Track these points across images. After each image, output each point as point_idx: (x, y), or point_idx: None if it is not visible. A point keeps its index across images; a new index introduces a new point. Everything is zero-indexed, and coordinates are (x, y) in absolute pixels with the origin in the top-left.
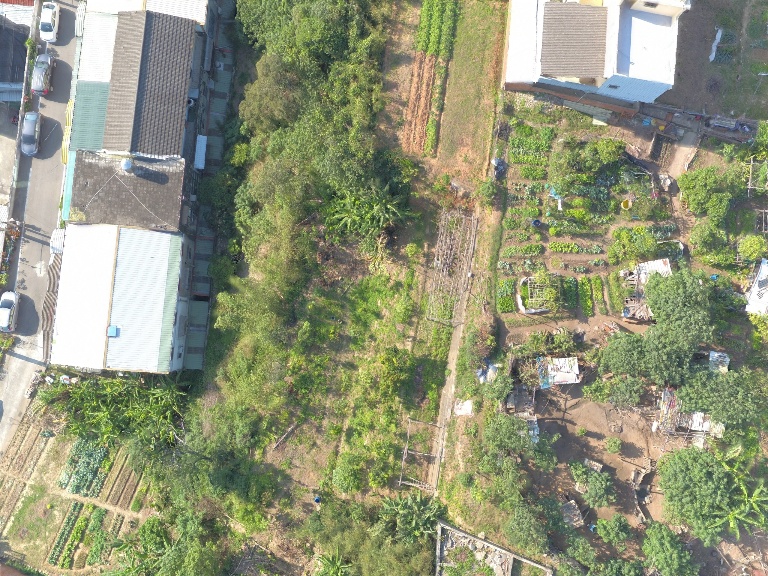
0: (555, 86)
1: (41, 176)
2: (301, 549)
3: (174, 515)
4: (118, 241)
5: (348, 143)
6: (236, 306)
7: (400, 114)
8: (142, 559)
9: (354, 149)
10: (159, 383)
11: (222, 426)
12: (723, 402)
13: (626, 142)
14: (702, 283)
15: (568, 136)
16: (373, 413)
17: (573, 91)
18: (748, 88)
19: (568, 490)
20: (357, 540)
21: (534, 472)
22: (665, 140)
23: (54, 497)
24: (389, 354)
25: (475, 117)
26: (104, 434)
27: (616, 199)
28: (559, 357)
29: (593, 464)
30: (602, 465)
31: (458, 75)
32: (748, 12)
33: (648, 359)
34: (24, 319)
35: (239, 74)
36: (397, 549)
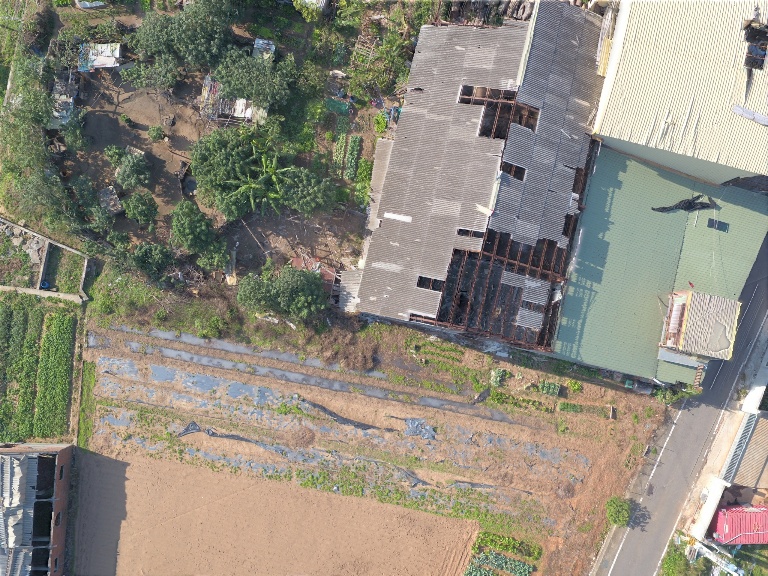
0: None
1: None
2: None
3: None
4: None
5: None
6: None
7: None
8: None
9: None
10: None
11: None
12: (249, 77)
13: None
14: None
15: None
16: None
17: None
18: None
19: (114, 180)
20: None
21: (82, 163)
22: None
23: None
24: None
25: None
26: None
27: None
28: (102, 43)
29: (134, 150)
30: None
31: None
32: None
33: (170, 30)
34: None
35: None
36: None
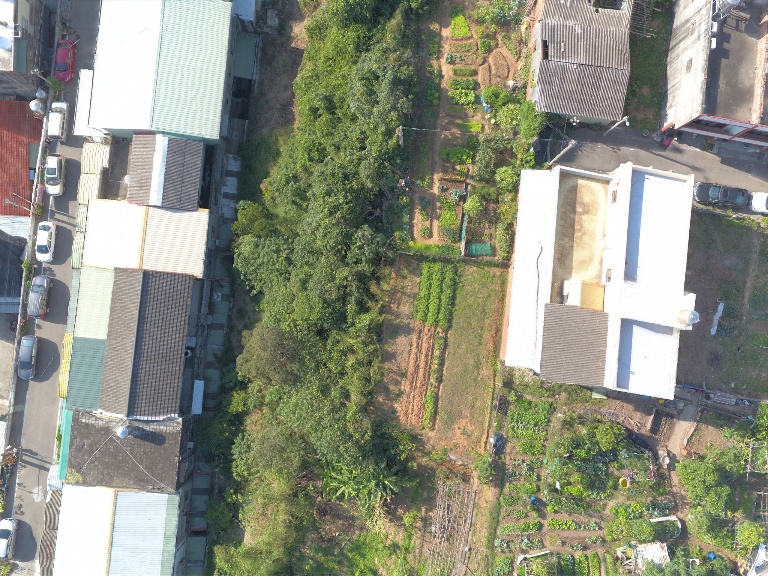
0: None
1: (38, 399)
2: None
3: None
4: (115, 506)
5: (346, 423)
6: None
7: (398, 386)
8: None
9: (352, 431)
10: None
11: None
12: None
13: (625, 416)
14: (699, 563)
15: (567, 417)
16: None
17: None
18: (749, 361)
19: None
20: None
21: None
22: (665, 414)
23: None
24: None
25: (474, 388)
26: None
27: (614, 474)
28: None
29: None
30: None
31: (457, 345)
32: (751, 282)
33: None
34: (22, 545)
35: (237, 307)
36: None
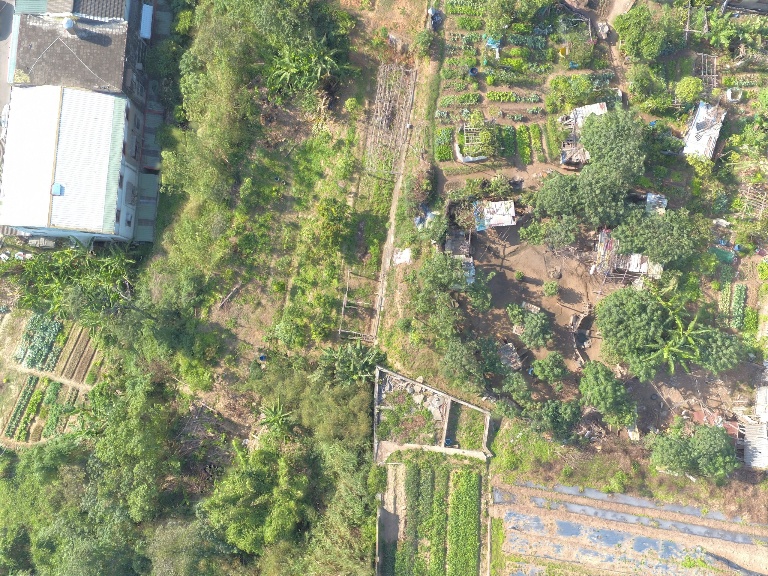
0: None
1: None
2: (247, 408)
3: (124, 380)
4: (62, 101)
5: None
6: (179, 165)
7: None
8: (92, 423)
9: None
10: None
11: (169, 289)
12: (658, 237)
13: None
14: None
15: None
16: (316, 270)
17: None
18: None
19: (506, 335)
20: (297, 388)
21: (473, 318)
22: None
23: (10, 372)
24: (328, 205)
25: None
26: (56, 304)
27: (554, 48)
28: (495, 201)
29: (530, 307)
30: (540, 308)
31: None
32: None
33: (581, 194)
34: None
35: None
36: (335, 392)
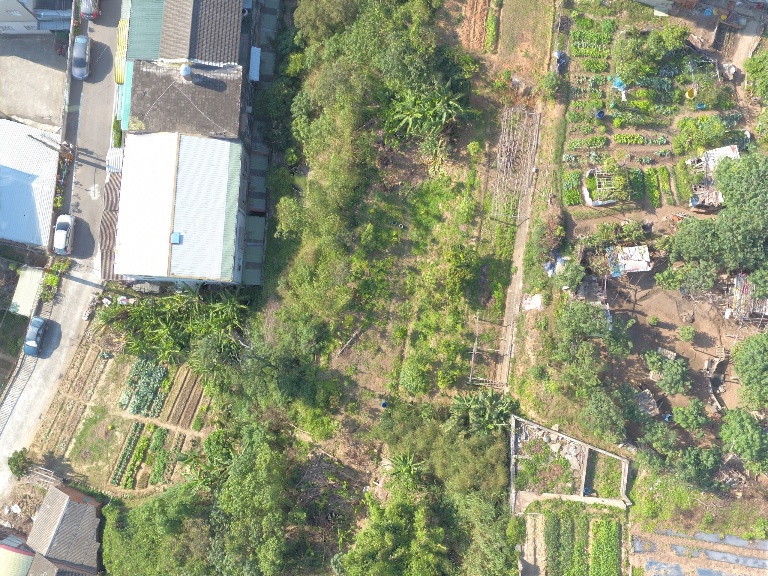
0: None
1: (92, 100)
2: (368, 455)
3: (238, 427)
4: (179, 148)
5: (409, 39)
6: (298, 211)
7: (459, 11)
8: (208, 471)
9: (416, 44)
10: (218, 299)
11: (285, 335)
12: None
13: None
14: None
15: (631, 25)
16: (438, 315)
17: None
18: None
19: (641, 381)
20: (429, 437)
21: (606, 364)
22: (728, 29)
23: (115, 418)
24: (455, 251)
25: (535, 12)
26: (165, 350)
27: (680, 89)
28: (629, 246)
29: (666, 352)
30: (675, 354)
31: None
32: None
33: (722, 240)
34: (80, 242)
35: None
36: (471, 442)
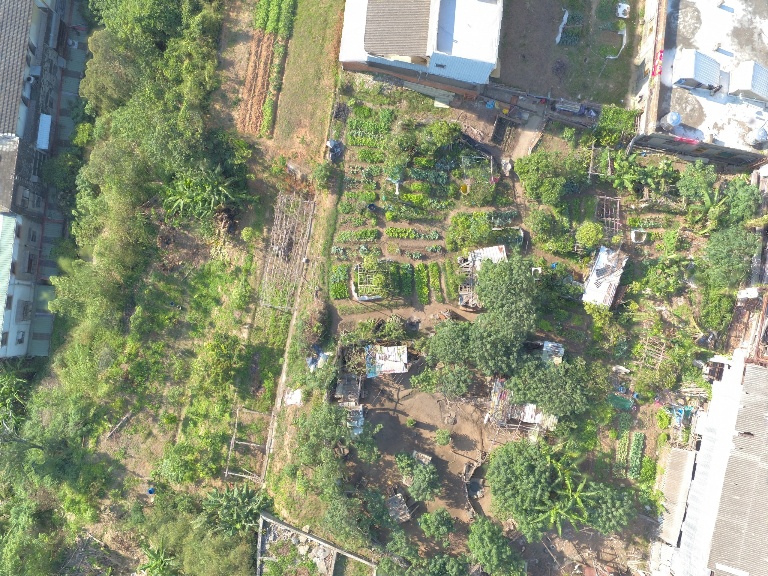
0: (393, 66)
1: None
2: (135, 542)
3: (10, 505)
4: None
5: (176, 122)
6: (68, 290)
7: (236, 93)
8: None
9: (182, 128)
10: None
11: (58, 414)
12: (550, 393)
13: (468, 125)
14: (541, 271)
15: (405, 118)
16: (208, 402)
17: (414, 72)
18: (595, 71)
19: (397, 483)
20: (180, 532)
21: (363, 464)
22: (509, 124)
23: None
24: (219, 341)
25: (314, 97)
26: None
27: (456, 184)
28: (388, 345)
29: (421, 456)
30: (431, 457)
31: (297, 54)
32: None
33: (472, 348)
34: None
35: None
36: (216, 542)
